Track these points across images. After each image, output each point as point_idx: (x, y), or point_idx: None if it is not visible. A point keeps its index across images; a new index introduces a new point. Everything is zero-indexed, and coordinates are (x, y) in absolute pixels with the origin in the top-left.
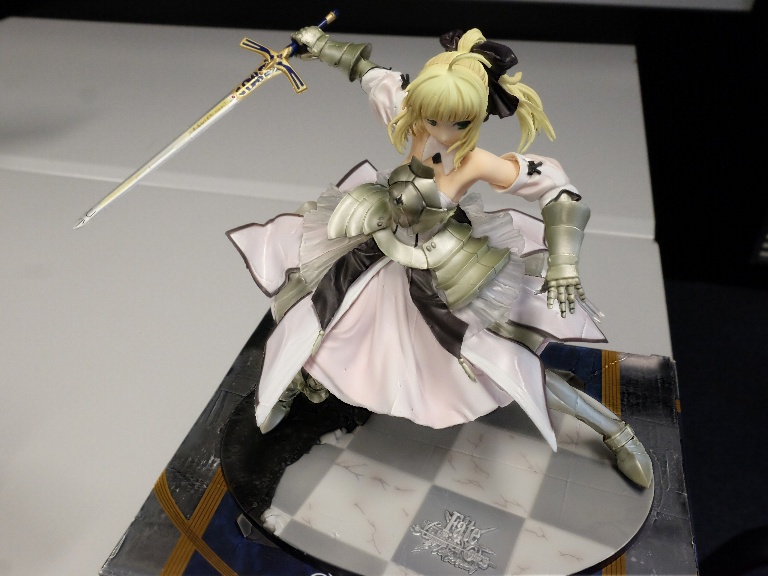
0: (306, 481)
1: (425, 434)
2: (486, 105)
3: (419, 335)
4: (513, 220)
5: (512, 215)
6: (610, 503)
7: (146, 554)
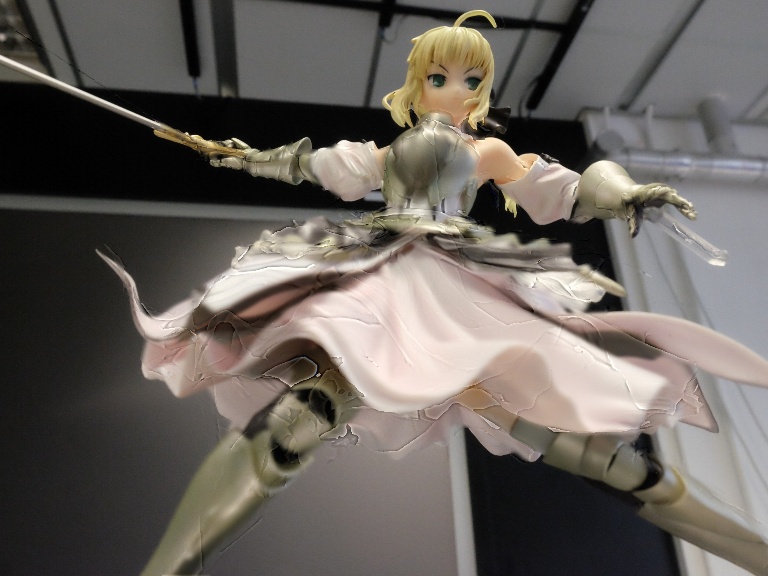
0: None
1: None
2: None
3: (499, 318)
4: None
5: None
6: None
7: None
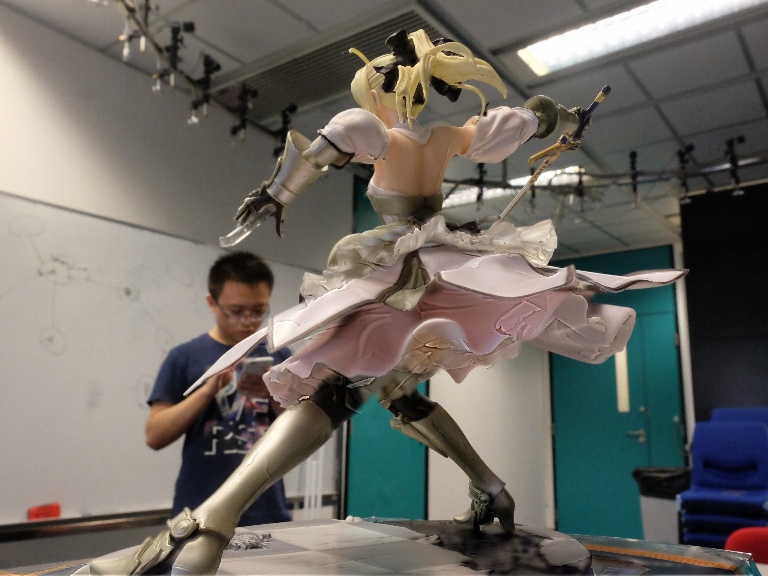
0: (381, 529)
1: (393, 558)
2: (365, 84)
3: None
4: None
5: None
6: None
7: (372, 520)
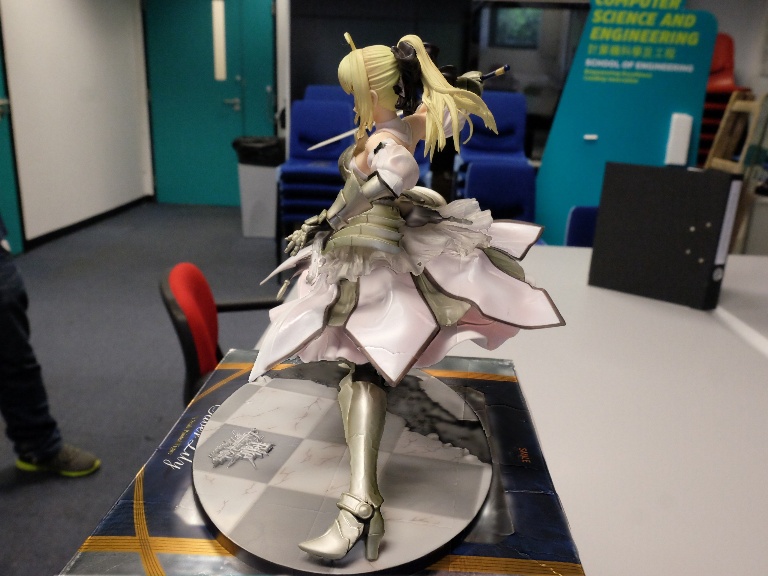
0: (299, 388)
1: None
2: (365, 82)
3: None
4: (533, 298)
5: (539, 294)
6: (289, 536)
7: (241, 357)
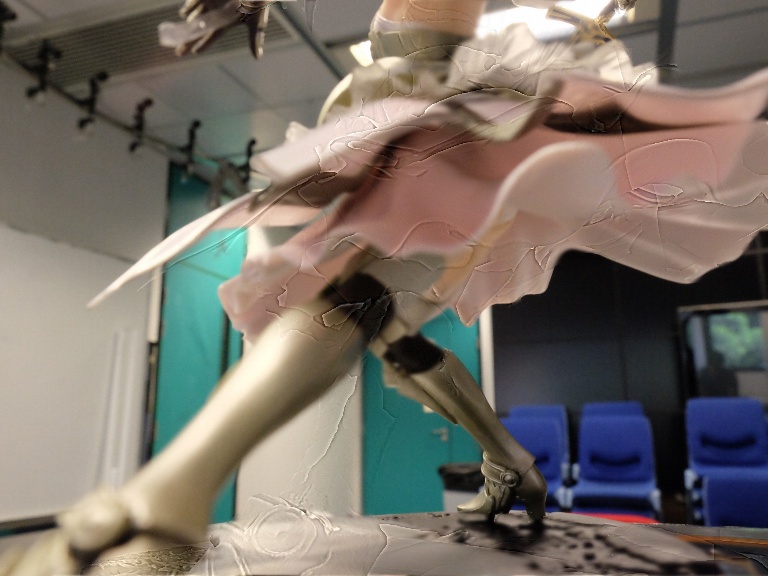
0: None
1: (460, 568)
2: None
3: None
4: None
5: None
6: None
7: None
